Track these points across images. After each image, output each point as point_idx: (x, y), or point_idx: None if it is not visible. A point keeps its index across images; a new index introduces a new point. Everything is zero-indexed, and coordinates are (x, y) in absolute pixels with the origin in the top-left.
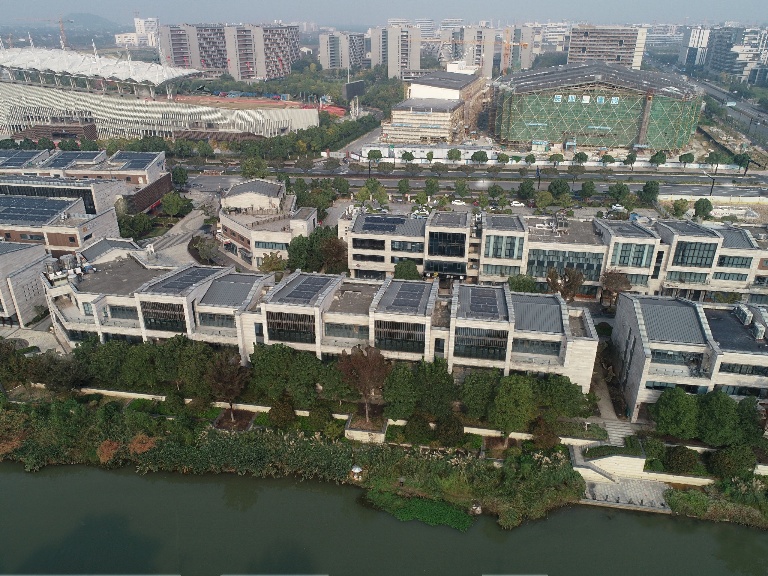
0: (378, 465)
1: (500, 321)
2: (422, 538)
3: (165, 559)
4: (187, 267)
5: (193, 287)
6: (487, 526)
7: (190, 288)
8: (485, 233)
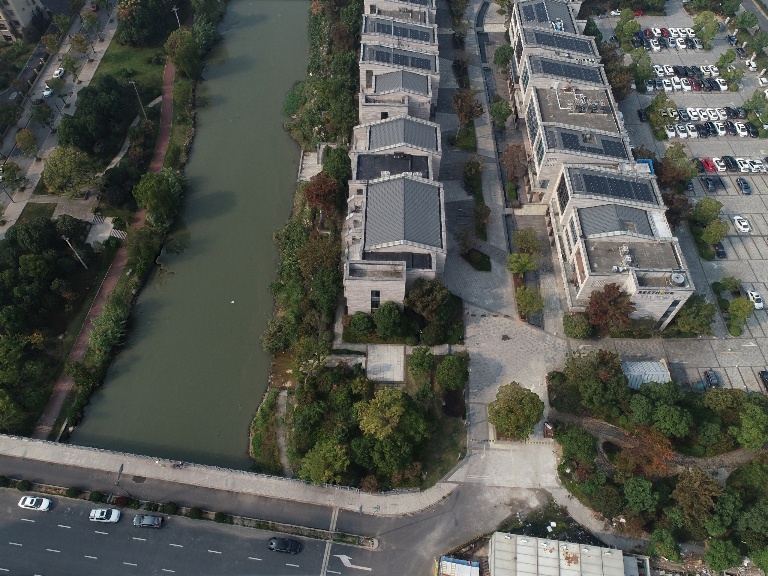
0: None
1: (361, 58)
2: (278, 102)
3: (264, 39)
4: None
5: None
6: (285, 120)
7: None
8: (525, 58)
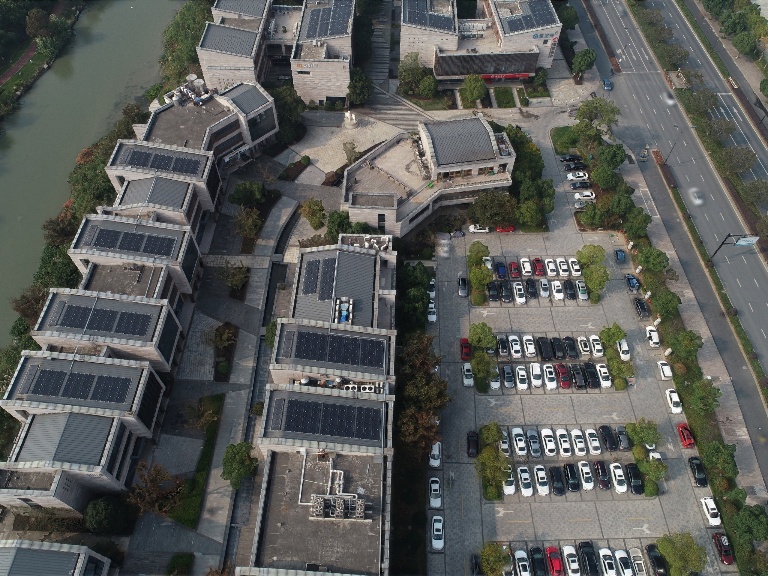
0: (7, 351)
1: (6, 392)
2: None
3: None
4: (199, 153)
5: (121, 168)
6: None
7: (119, 167)
8: None
